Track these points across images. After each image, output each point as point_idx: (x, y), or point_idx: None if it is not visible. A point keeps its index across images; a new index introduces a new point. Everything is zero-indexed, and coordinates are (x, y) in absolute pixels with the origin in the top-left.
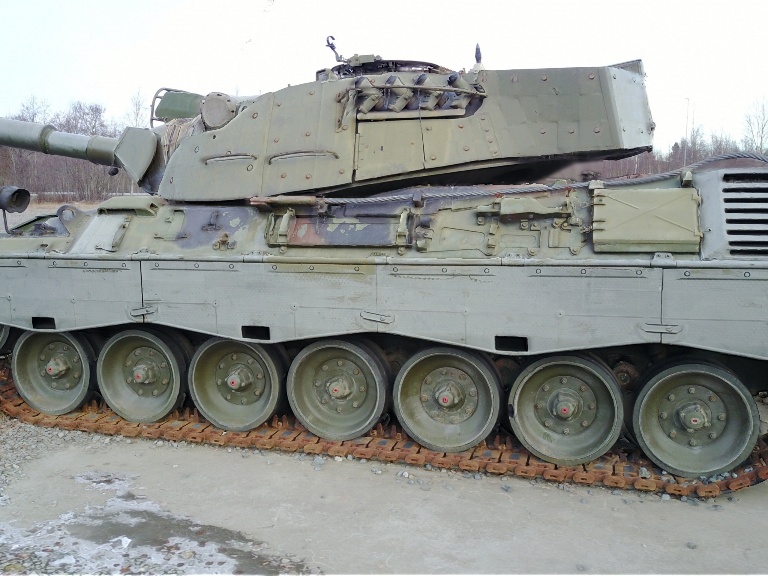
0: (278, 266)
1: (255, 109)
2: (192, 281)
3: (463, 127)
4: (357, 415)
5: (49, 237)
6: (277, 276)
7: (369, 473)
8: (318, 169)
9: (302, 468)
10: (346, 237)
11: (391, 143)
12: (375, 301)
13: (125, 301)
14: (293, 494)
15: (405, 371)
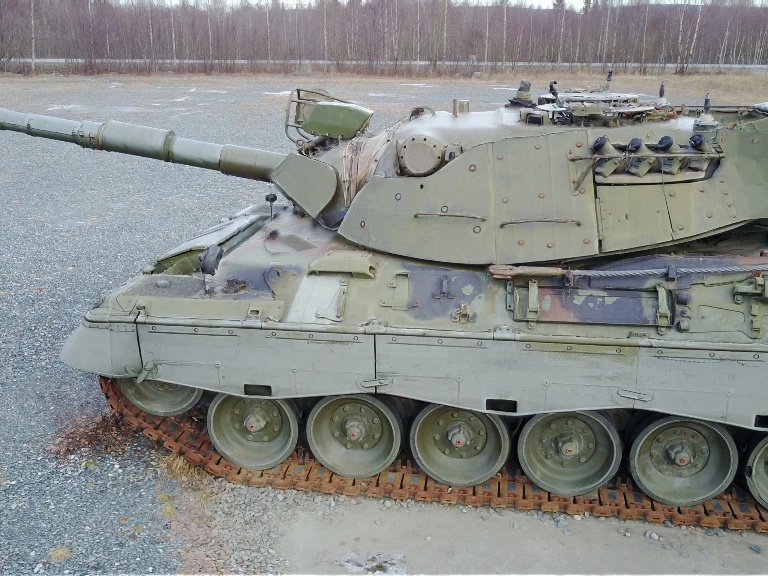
0: (532, 345)
1: (471, 160)
2: (434, 356)
3: (704, 191)
4: (584, 469)
5: (253, 299)
6: (530, 354)
7: (618, 535)
8: (559, 237)
9: (551, 533)
10: (597, 312)
11: (636, 211)
12: (635, 381)
13: (355, 373)
14: (571, 574)
15: (645, 435)
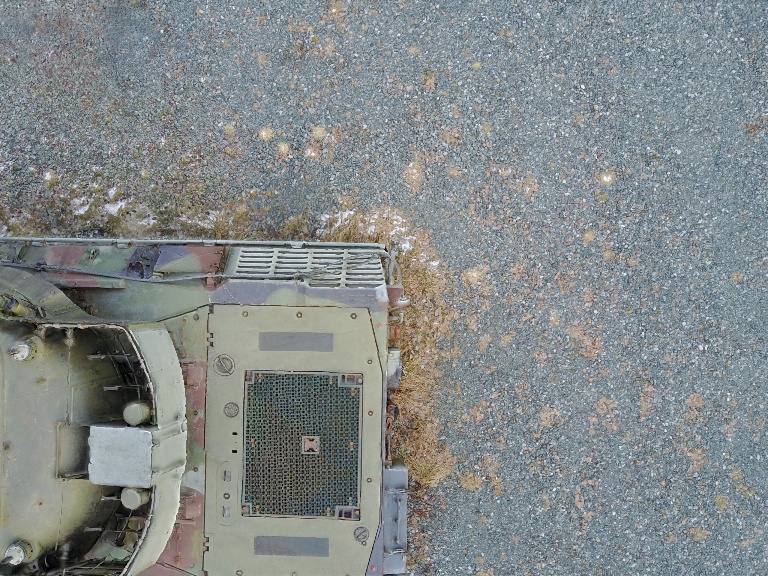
0: None
1: None
2: None
3: None
4: None
5: None
6: None
7: None
8: None
9: None
10: None
11: None
12: None
13: None
14: None
15: None
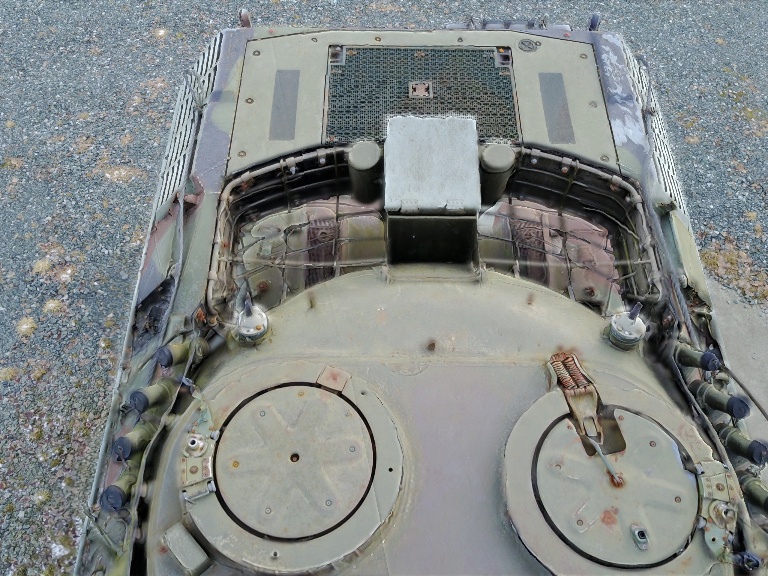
0: None
1: None
2: None
3: None
4: None
5: None
6: None
7: None
8: None
9: None
10: None
11: None
12: None
13: None
14: None
15: None
